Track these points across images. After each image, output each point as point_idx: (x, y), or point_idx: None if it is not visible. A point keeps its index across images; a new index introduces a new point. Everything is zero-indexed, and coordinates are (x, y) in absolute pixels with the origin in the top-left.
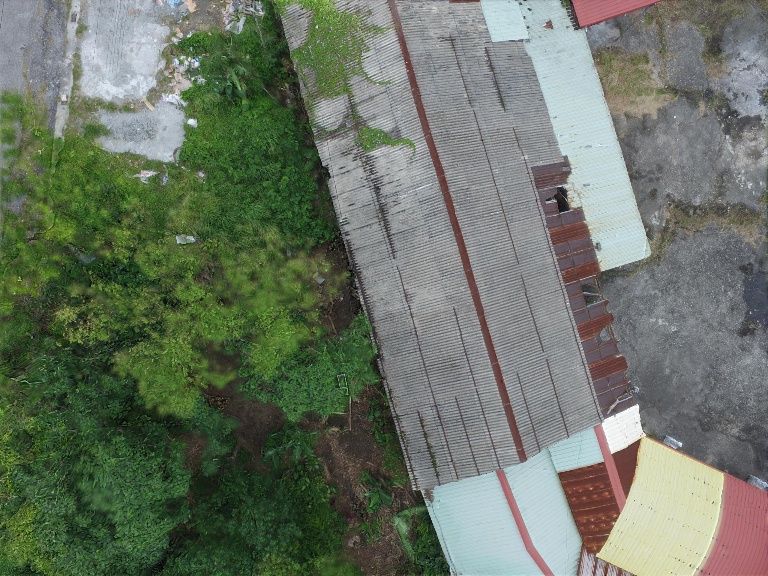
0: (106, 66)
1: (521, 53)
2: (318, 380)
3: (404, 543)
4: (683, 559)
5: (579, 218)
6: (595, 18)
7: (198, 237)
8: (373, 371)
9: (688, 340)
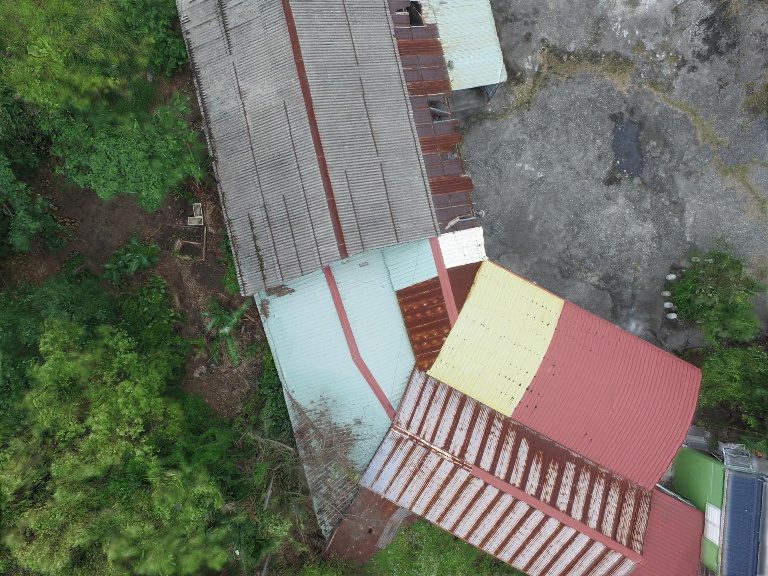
0: None
1: None
2: (129, 155)
3: (229, 350)
4: (513, 378)
5: (432, 34)
6: None
7: (50, 49)
8: None
9: (553, 186)
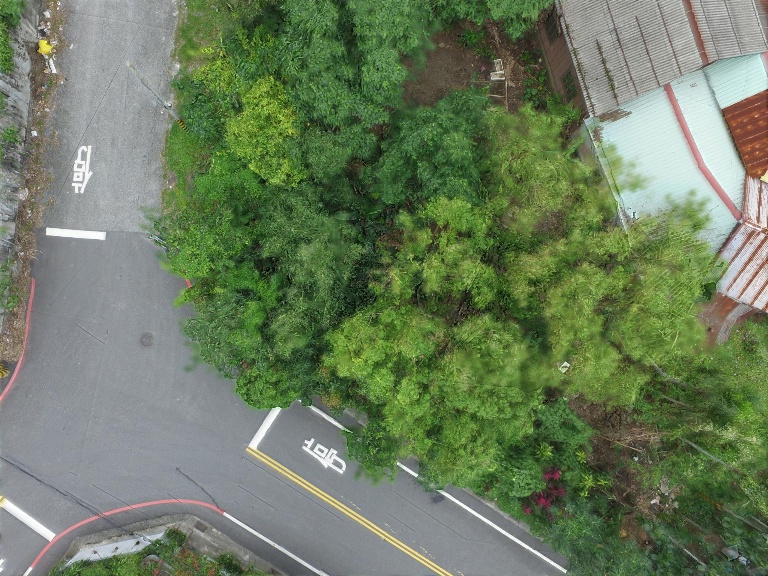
0: None
1: None
2: None
3: (582, 166)
4: None
5: None
6: None
7: None
8: (529, 54)
9: None
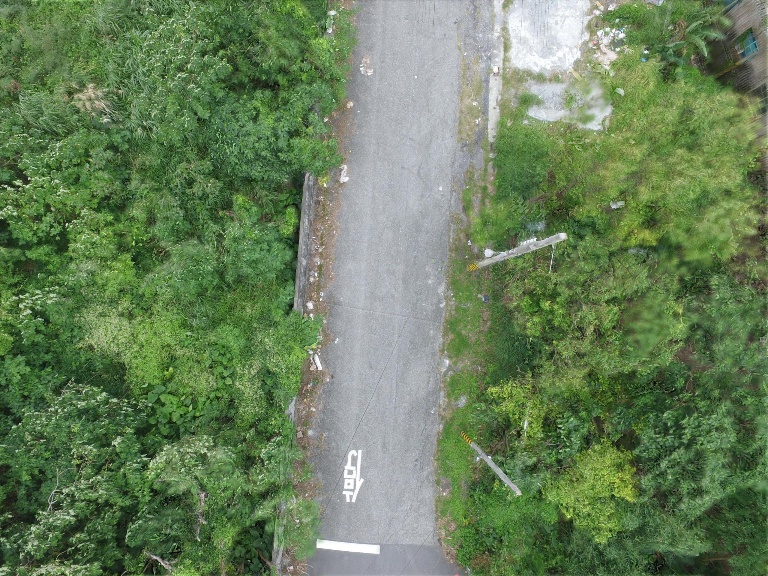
0: (533, 39)
1: None
2: None
3: None
4: None
5: None
6: None
7: (630, 202)
8: None
9: None
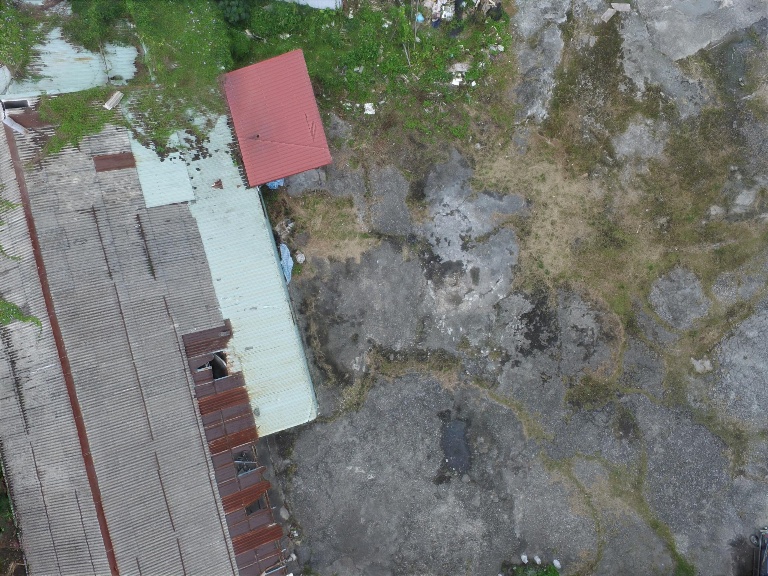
0: None
1: (184, 216)
2: None
3: None
4: None
5: (237, 383)
6: (263, 179)
7: None
8: None
9: (384, 488)
